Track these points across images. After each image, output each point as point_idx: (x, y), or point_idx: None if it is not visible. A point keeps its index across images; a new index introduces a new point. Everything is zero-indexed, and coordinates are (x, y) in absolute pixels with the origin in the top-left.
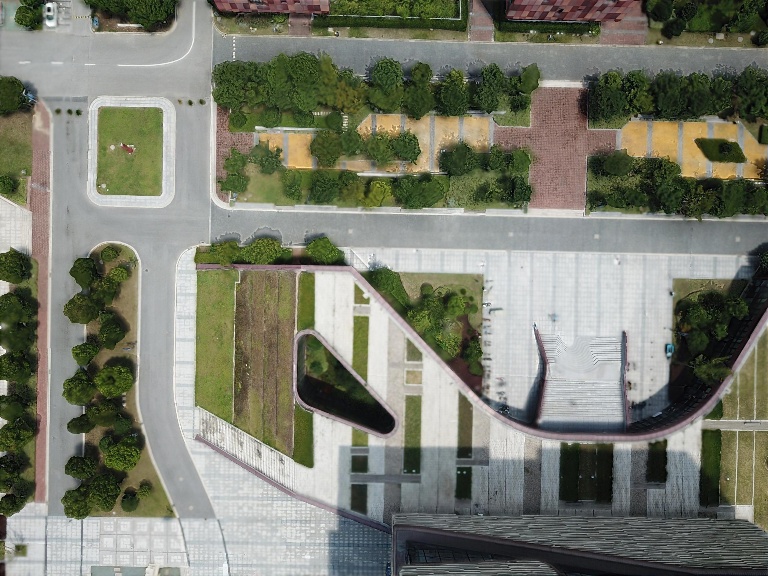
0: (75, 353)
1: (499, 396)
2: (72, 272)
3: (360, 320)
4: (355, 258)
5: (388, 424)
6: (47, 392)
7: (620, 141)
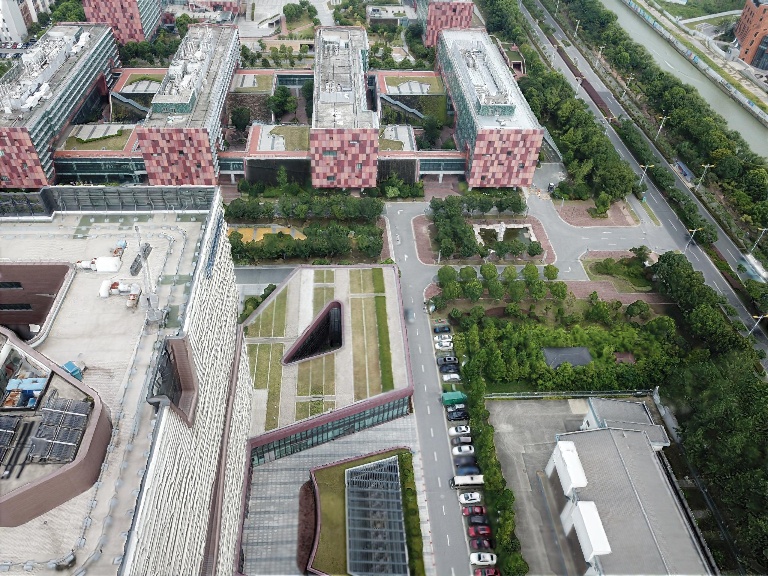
0: None
1: None
2: None
3: None
4: None
5: None
6: None
7: None
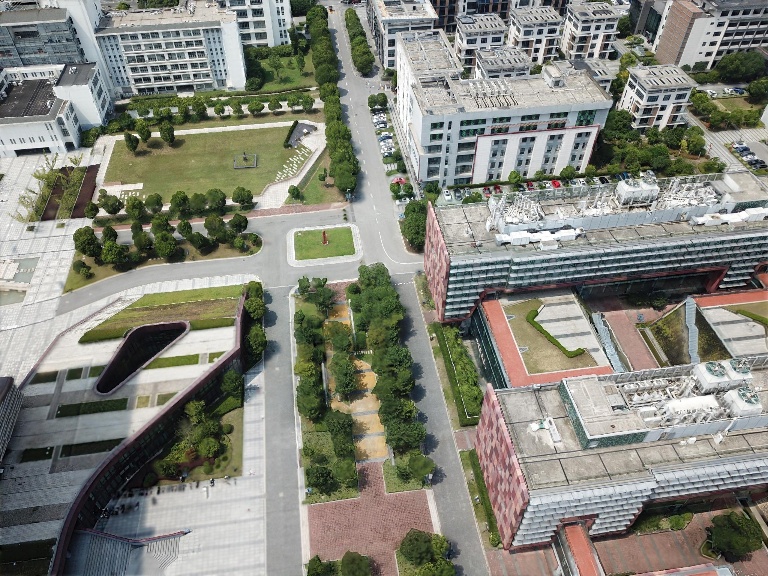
0: (184, 220)
1: (120, 507)
2: (237, 214)
3: (196, 358)
4: (255, 375)
5: None
6: None
7: None
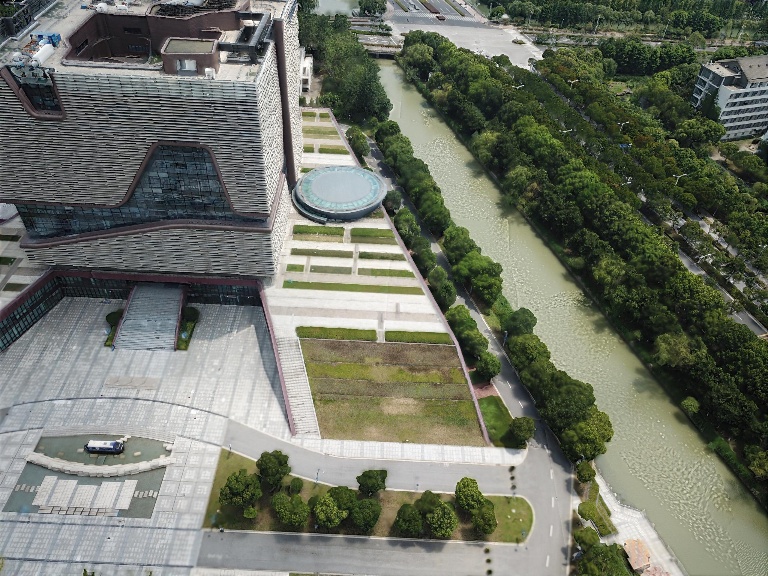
0: None
1: None
2: None
3: None
4: None
5: None
6: None
7: None
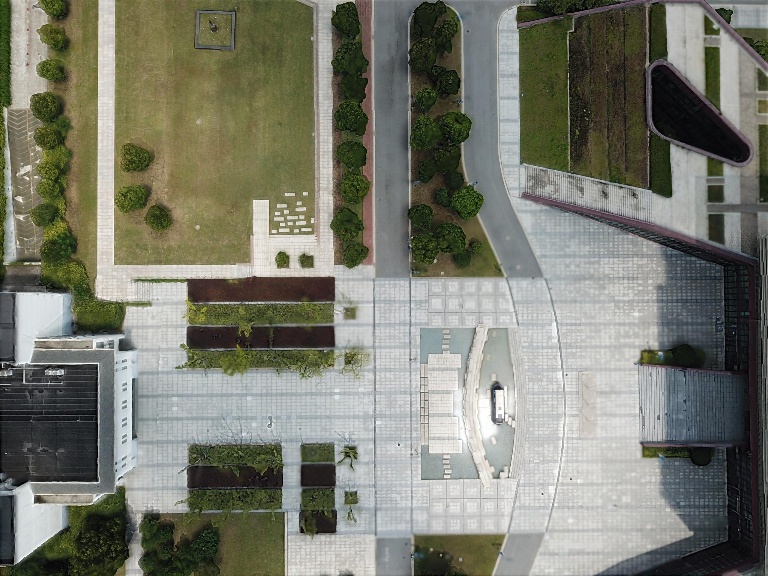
0: (426, 92)
1: None
2: (422, 12)
3: (711, 51)
4: None
5: None
6: (372, 153)
7: None
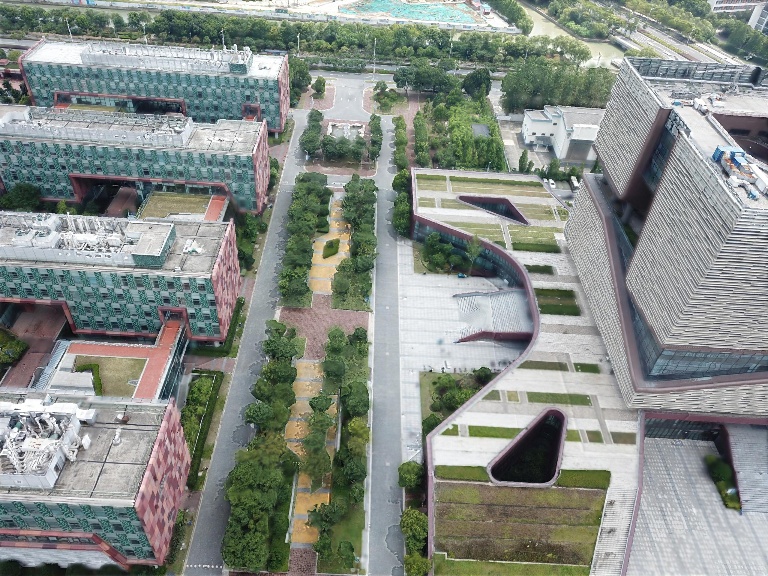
0: None
1: None
2: None
3: (472, 432)
4: None
5: (554, 429)
6: None
7: (321, 292)
